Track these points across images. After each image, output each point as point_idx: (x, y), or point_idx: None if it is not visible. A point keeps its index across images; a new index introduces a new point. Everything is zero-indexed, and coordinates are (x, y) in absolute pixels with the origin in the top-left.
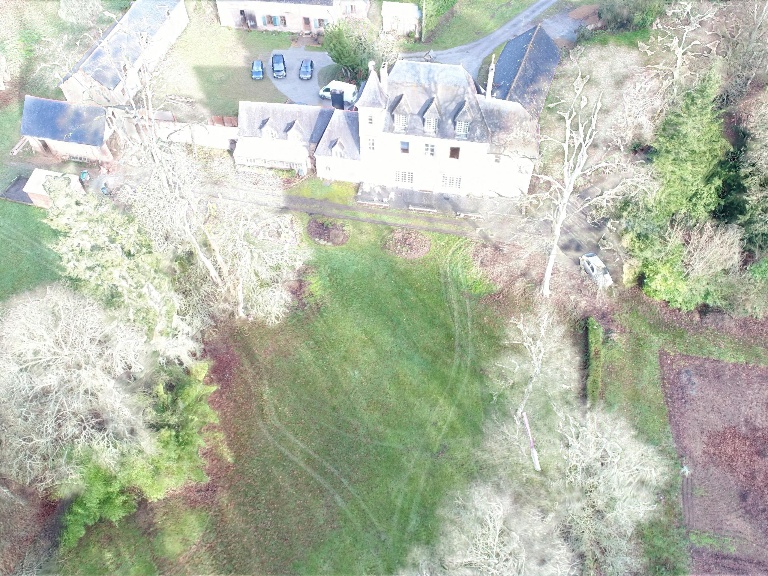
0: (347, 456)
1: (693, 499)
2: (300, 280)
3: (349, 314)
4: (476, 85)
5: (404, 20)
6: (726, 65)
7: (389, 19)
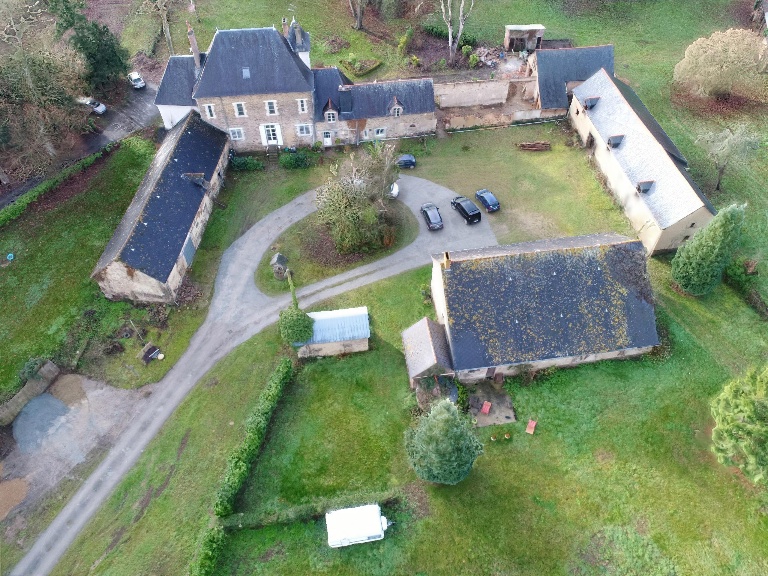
0: (280, 1)
1: None
2: (332, 44)
3: None
4: None
5: None
6: None
7: None
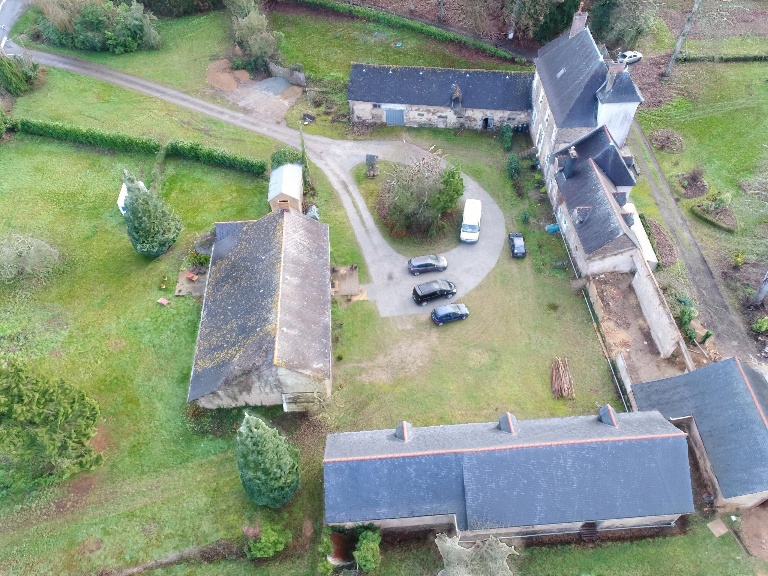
0: None
1: (761, 33)
2: (760, 184)
3: (763, 156)
4: None
5: None
6: None
7: None
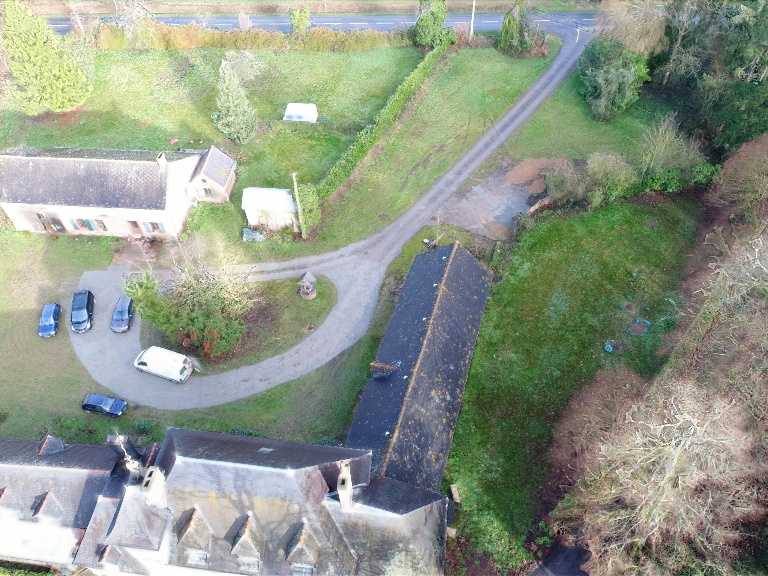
0: None
1: None
2: None
3: None
4: (328, 472)
5: (275, 214)
6: (751, 423)
7: (254, 213)
